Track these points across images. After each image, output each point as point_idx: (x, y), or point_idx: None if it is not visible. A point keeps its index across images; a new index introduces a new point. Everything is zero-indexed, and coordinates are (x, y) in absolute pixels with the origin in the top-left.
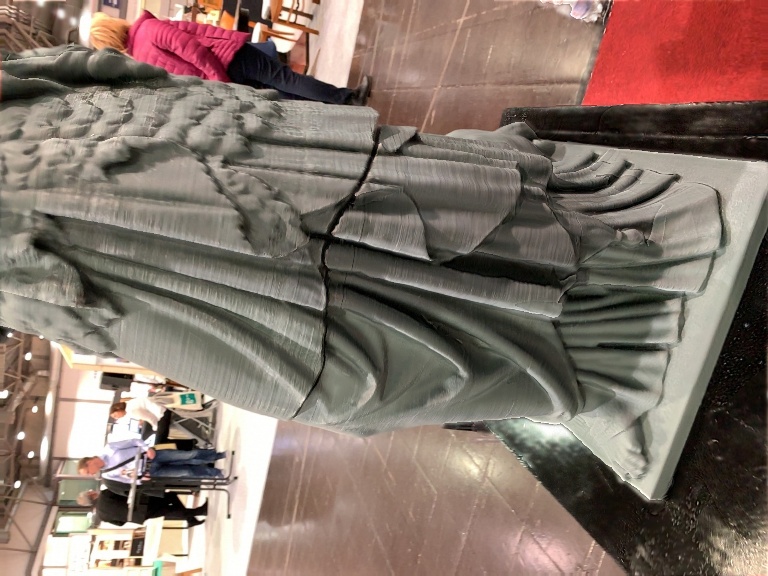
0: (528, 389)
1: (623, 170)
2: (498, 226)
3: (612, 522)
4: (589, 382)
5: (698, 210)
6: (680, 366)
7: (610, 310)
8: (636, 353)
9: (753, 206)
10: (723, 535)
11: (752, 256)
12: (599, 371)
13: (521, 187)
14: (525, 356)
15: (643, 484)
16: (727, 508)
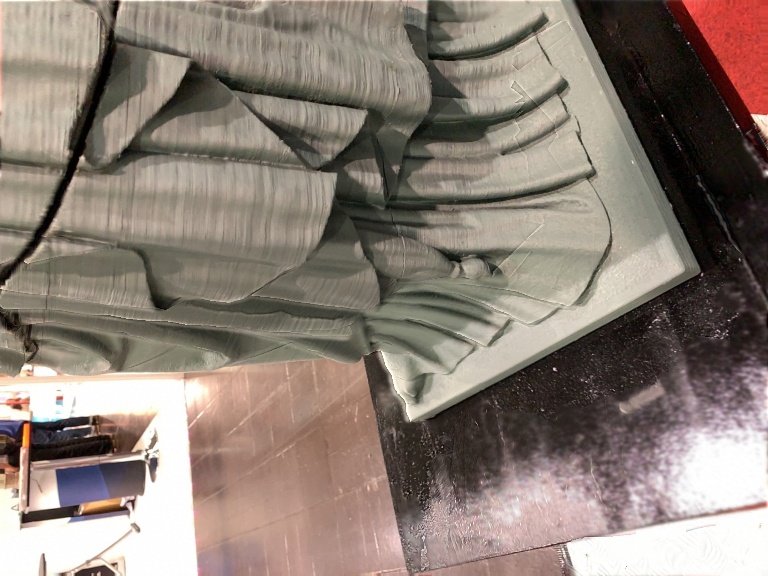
0: (310, 350)
1: (550, 95)
2: (274, 279)
3: (385, 395)
4: (385, 342)
5: (573, 259)
6: (478, 363)
7: (431, 297)
8: (443, 335)
9: (630, 291)
10: (445, 482)
11: (599, 324)
12: (399, 336)
13: (325, 230)
14: (305, 344)
15: (410, 407)
16: (457, 472)
